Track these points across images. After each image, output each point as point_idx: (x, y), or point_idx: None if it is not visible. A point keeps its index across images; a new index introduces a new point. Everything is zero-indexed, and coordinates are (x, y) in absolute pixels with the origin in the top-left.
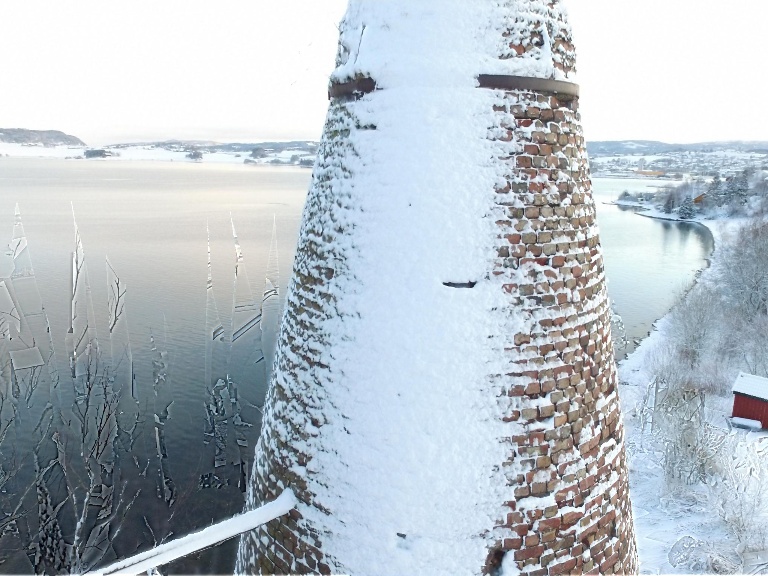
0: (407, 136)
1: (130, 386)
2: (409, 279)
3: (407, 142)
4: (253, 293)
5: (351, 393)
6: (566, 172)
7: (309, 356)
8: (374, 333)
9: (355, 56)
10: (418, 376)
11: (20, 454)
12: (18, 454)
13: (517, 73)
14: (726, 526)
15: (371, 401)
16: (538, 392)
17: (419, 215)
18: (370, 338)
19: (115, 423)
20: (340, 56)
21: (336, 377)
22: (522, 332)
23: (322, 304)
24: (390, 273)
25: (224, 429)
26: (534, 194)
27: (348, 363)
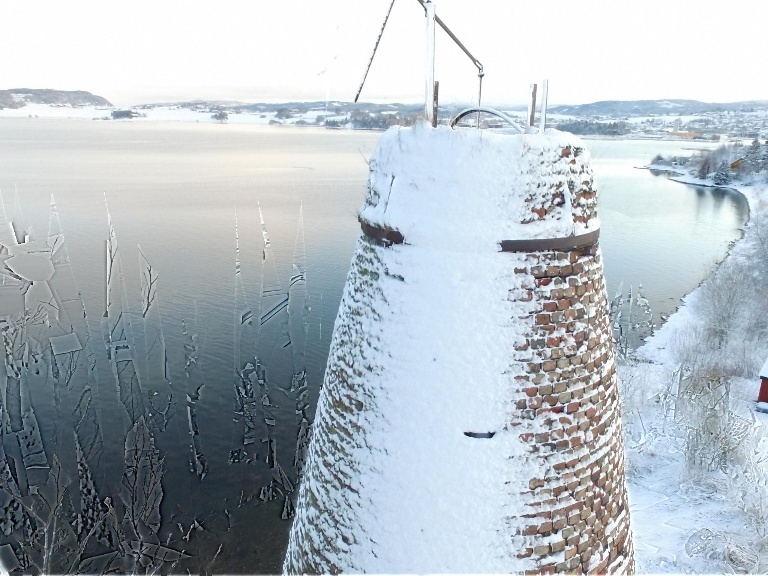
0: (433, 296)
1: (163, 368)
2: (433, 427)
3: (433, 301)
4: (280, 278)
5: (378, 521)
6: (583, 321)
7: (340, 477)
8: (400, 472)
9: (385, 204)
10: (440, 516)
11: (61, 430)
12: (59, 430)
13: (538, 236)
14: (745, 516)
15: (397, 532)
16: (550, 530)
17: (443, 371)
18: (396, 475)
19: (160, 489)
20: (370, 194)
21: (365, 504)
22: (537, 477)
23: (352, 432)
24: (415, 420)
25: (253, 409)
26: (551, 348)
27: (376, 494)
